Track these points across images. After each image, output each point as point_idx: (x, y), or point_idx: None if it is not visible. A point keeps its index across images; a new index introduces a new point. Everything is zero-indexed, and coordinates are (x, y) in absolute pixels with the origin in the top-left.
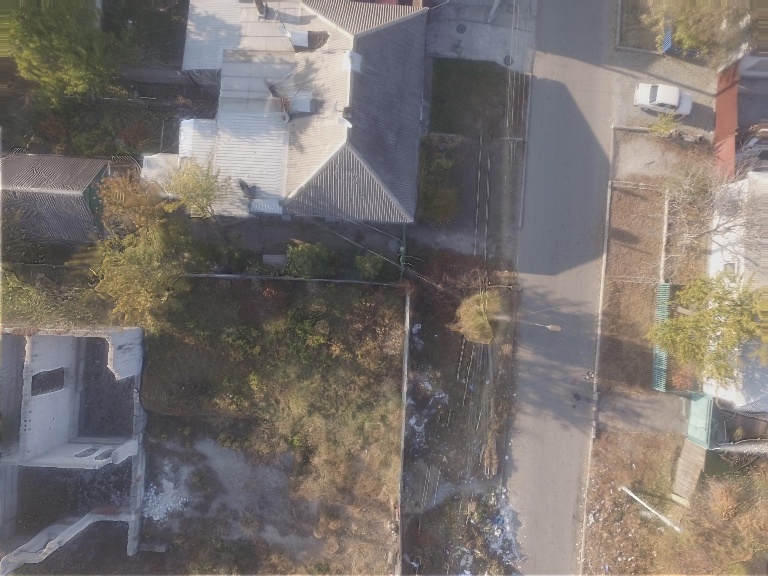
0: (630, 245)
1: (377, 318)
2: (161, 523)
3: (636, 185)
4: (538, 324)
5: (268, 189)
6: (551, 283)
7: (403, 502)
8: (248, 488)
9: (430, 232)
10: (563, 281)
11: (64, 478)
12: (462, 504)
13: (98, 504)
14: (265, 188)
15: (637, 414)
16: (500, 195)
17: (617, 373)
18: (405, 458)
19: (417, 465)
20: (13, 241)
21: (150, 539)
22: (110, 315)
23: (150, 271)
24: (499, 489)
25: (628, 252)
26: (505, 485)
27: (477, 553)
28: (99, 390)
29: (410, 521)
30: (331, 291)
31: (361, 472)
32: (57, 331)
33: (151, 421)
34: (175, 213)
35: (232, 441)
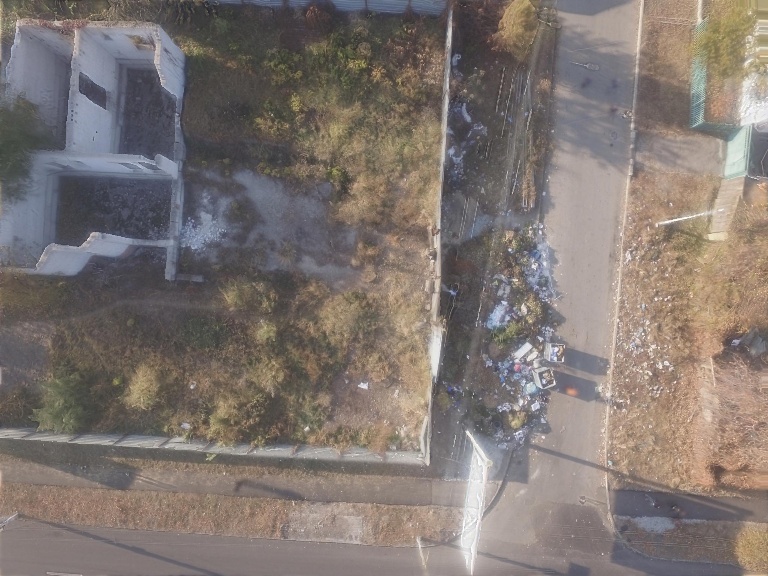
0: None
1: (418, 45)
2: (199, 252)
3: None
4: (576, 63)
5: None
6: (589, 22)
7: (441, 232)
8: (286, 218)
9: None
10: (601, 21)
11: (102, 214)
12: (500, 233)
13: None
14: None
15: (674, 154)
16: None
17: (654, 112)
18: (444, 182)
19: (455, 196)
20: None
21: (188, 268)
22: None
23: None
24: (536, 224)
25: None
26: (542, 221)
27: (514, 282)
28: (139, 127)
29: (448, 252)
30: (372, 21)
31: (400, 198)
32: (106, 23)
33: (190, 154)
34: None
35: (272, 168)
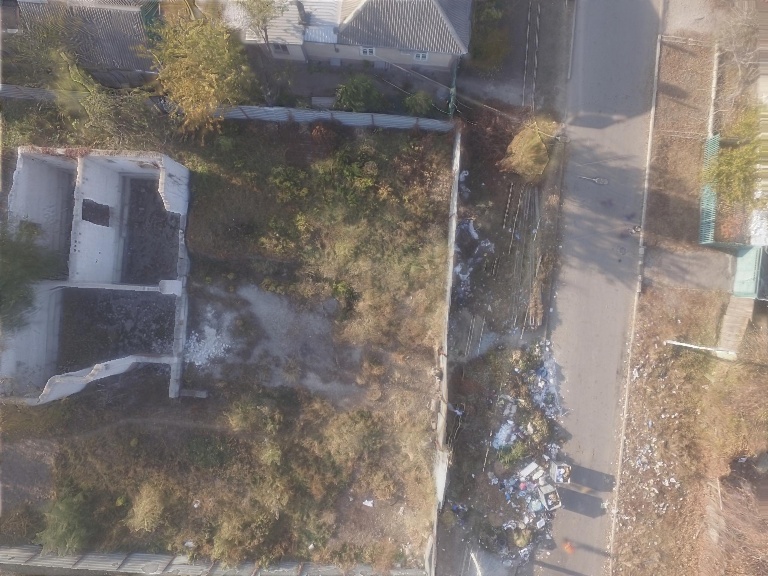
0: (679, 99)
1: (425, 163)
2: (203, 368)
3: (685, 40)
4: (585, 177)
5: (325, 10)
6: (599, 136)
7: (447, 350)
8: (291, 335)
9: (478, 82)
10: (611, 134)
11: (105, 326)
12: (507, 352)
13: (139, 352)
14: (322, 10)
15: (683, 270)
16: (549, 46)
17: (663, 228)
18: (451, 302)
19: (462, 314)
20: (67, 63)
21: (191, 384)
22: (165, 129)
23: (215, 55)
24: (543, 341)
25: (676, 106)
26: (549, 338)
27: (521, 402)
28: (142, 238)
29: (454, 370)
30: (379, 136)
31: (406, 317)
32: (109, 152)
33: (194, 267)
34: (231, 34)
35: (276, 285)
